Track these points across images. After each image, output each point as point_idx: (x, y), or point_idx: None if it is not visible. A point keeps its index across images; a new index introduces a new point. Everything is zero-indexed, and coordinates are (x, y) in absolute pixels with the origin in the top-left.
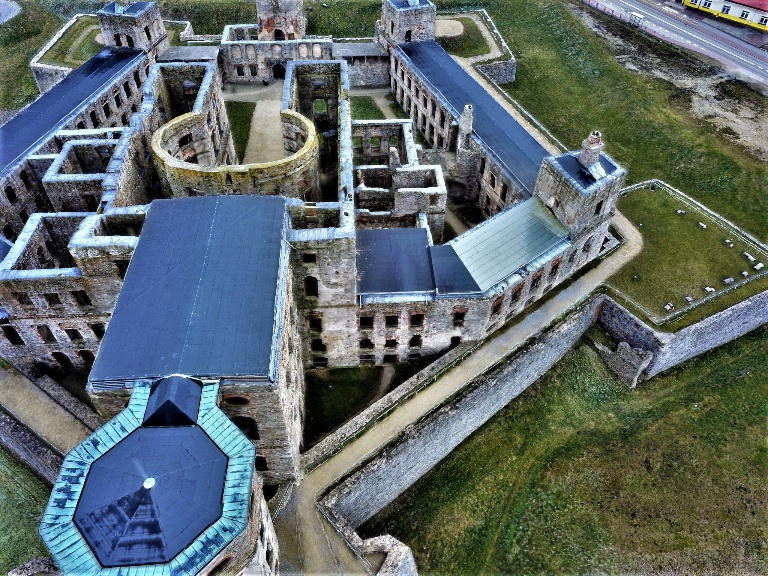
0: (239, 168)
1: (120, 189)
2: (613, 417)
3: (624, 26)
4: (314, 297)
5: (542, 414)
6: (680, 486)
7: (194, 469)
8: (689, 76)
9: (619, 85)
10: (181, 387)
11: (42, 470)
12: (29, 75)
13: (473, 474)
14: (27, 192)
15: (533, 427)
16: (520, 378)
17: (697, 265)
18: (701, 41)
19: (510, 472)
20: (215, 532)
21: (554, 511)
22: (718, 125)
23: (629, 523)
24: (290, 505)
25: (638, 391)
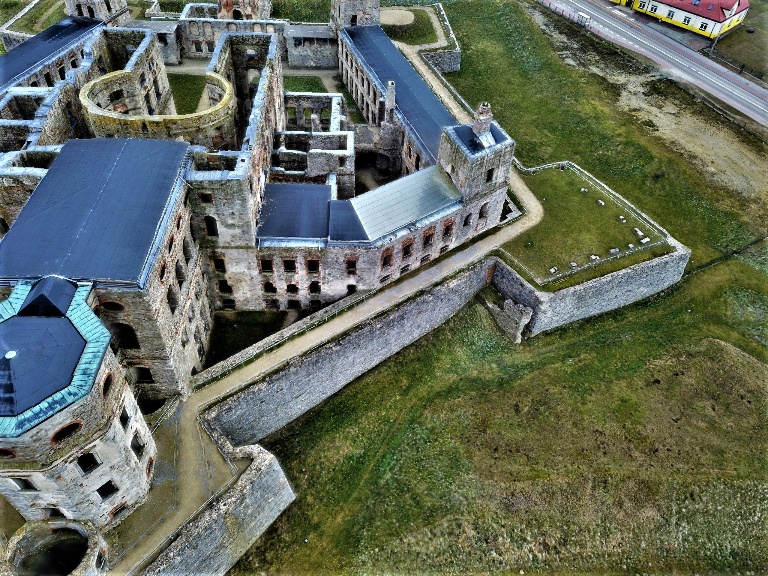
0: (154, 118)
1: (47, 132)
2: (495, 367)
3: (571, 25)
4: (215, 237)
5: (430, 362)
6: (542, 427)
7: (53, 348)
8: (623, 73)
9: (555, 78)
10: (56, 285)
11: None
12: (1, 42)
13: (358, 409)
14: None
15: (420, 372)
16: (410, 326)
17: (588, 236)
18: (642, 43)
19: (392, 410)
20: (61, 396)
21: (426, 443)
22: (641, 118)
23: (491, 456)
24: (174, 417)
25: (522, 346)
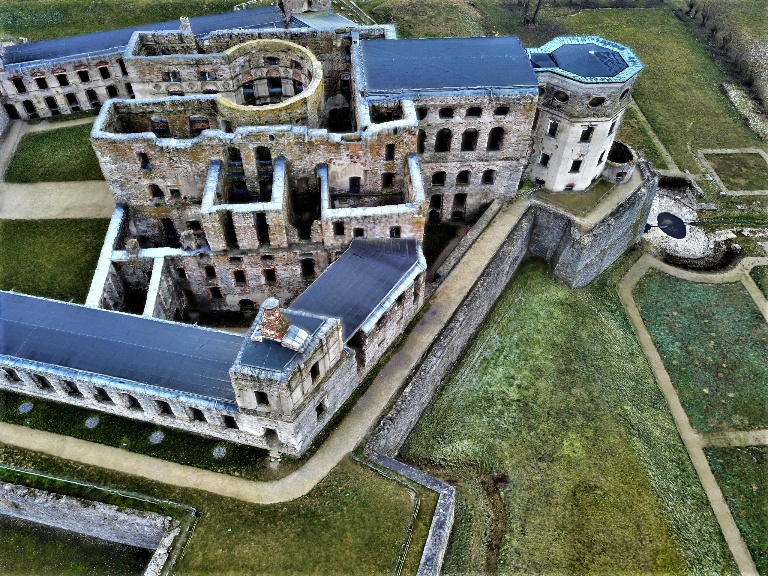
0: (318, 63)
1: None
2: None
3: None
4: None
5: None
6: None
7: None
8: None
9: (88, 6)
10: None
11: None
12: None
13: None
14: None
15: None
16: None
17: None
18: None
19: None
20: (600, 43)
21: None
22: None
23: None
24: None
25: None
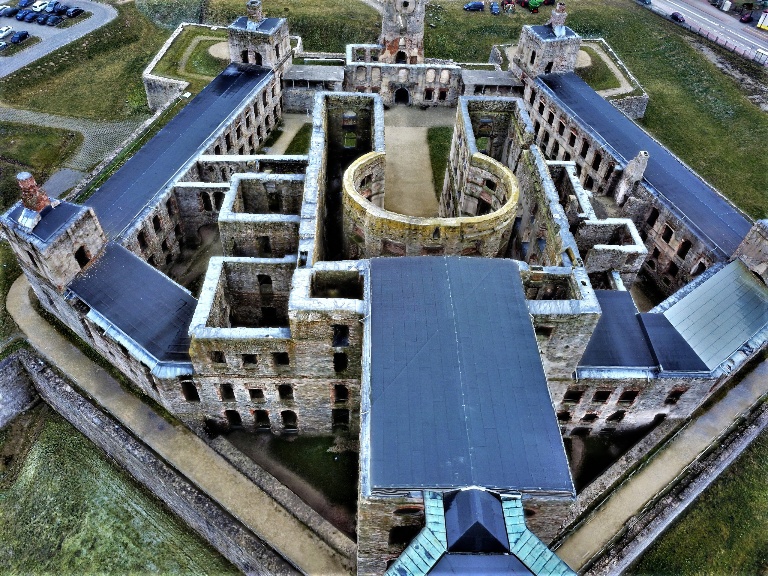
0: (451, 222)
1: (315, 237)
2: None
3: (749, 63)
4: None
5: (743, 500)
6: None
7: None
8: None
9: (758, 128)
10: (484, 503)
11: (219, 544)
12: (133, 85)
13: (681, 569)
14: (170, 221)
15: (737, 515)
16: (726, 461)
17: None
18: None
19: (720, 568)
20: None
21: None
22: None
23: None
24: None
25: None
